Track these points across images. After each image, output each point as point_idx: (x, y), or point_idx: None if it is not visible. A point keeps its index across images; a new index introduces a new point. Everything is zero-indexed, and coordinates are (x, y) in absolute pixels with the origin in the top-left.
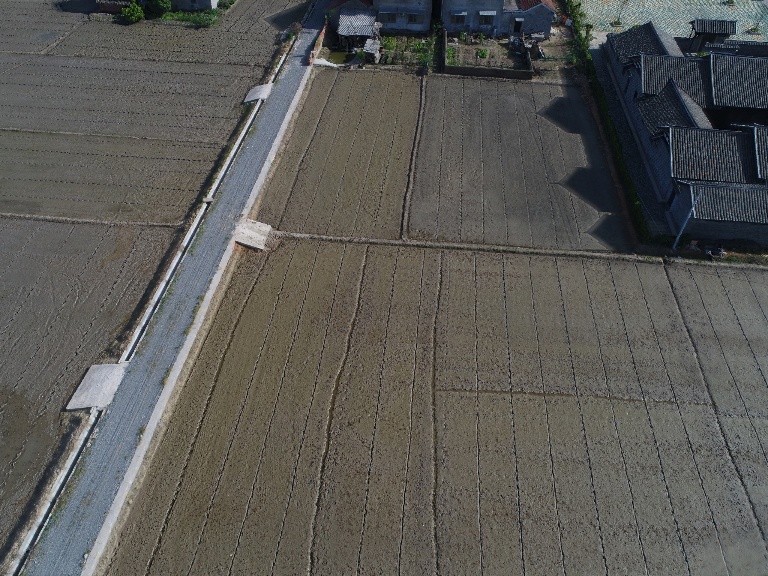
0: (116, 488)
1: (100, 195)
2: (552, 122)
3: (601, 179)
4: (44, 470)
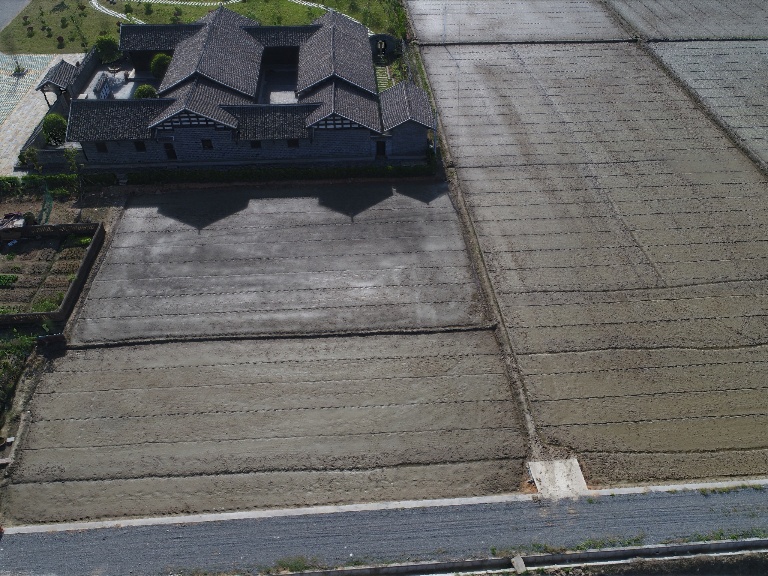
0: None
1: None
2: (223, 217)
3: (338, 191)
4: None
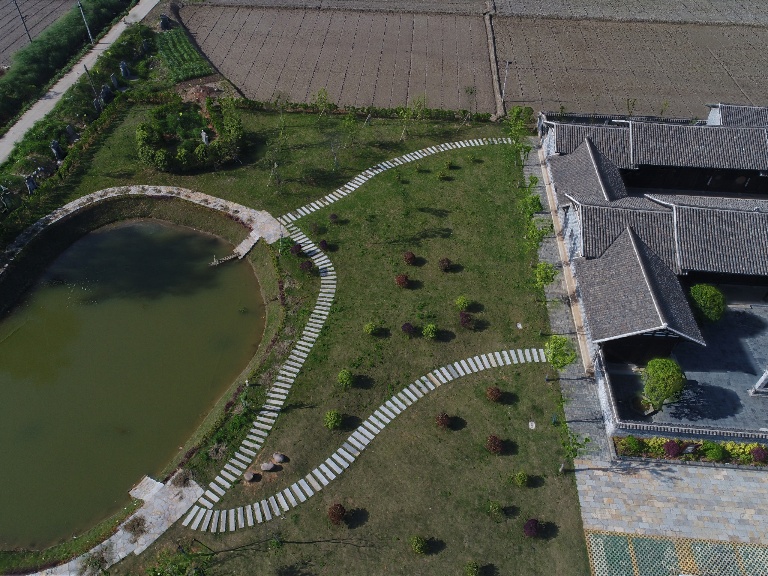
0: None
1: None
2: None
3: None
4: None
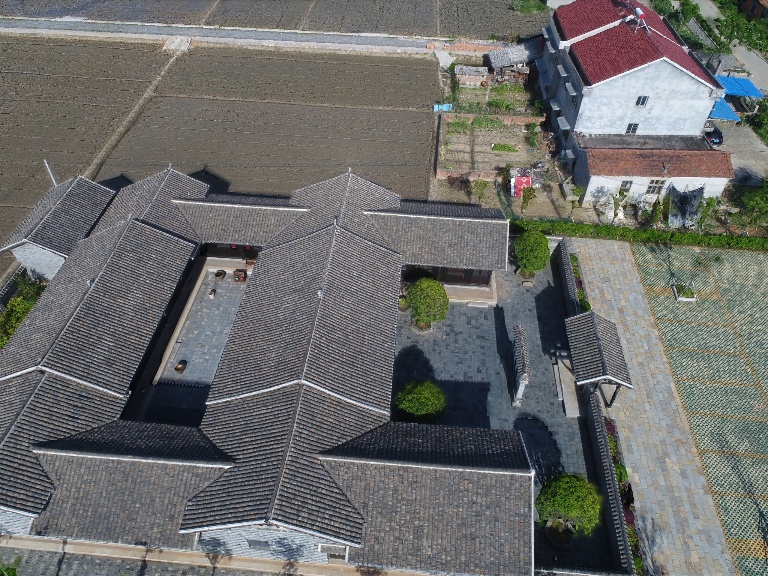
0: (8, 27)
1: (243, 5)
2: None
3: None
4: None
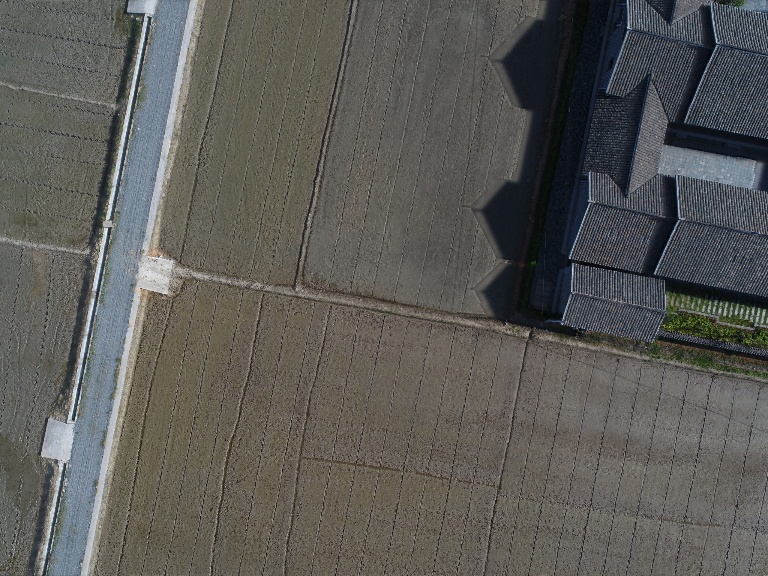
0: (89, 523)
1: (0, 196)
2: (502, 81)
3: (519, 202)
4: (41, 499)
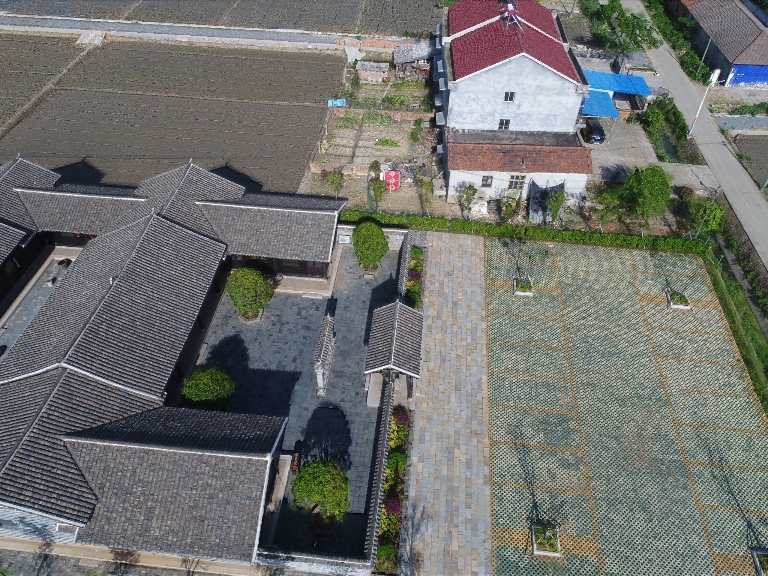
0: None
1: (169, 1)
2: None
3: None
4: None
